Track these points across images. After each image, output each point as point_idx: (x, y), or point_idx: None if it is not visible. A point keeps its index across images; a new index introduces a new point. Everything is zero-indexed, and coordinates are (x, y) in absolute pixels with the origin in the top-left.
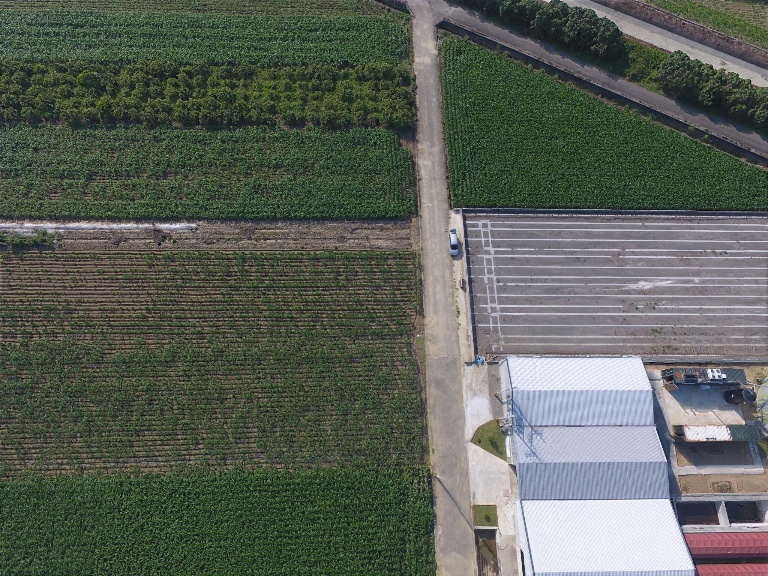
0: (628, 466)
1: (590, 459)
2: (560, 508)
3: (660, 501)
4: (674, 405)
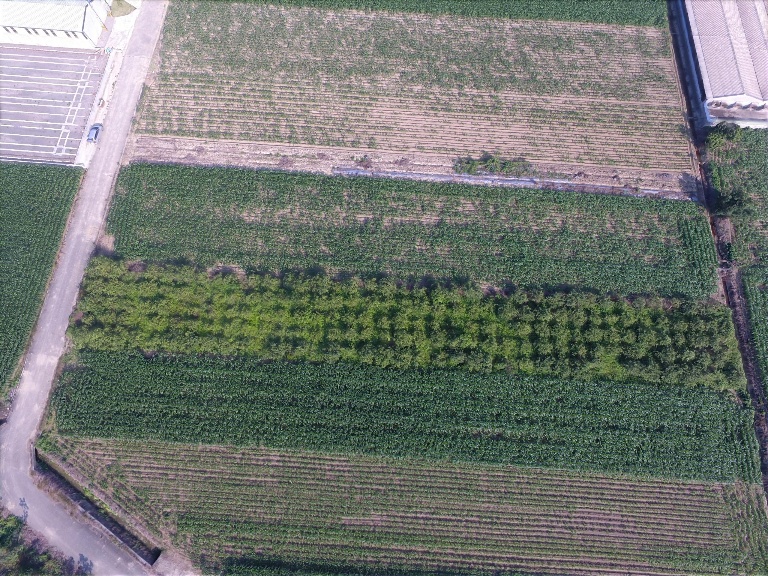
0: None
1: None
2: None
3: None
4: None
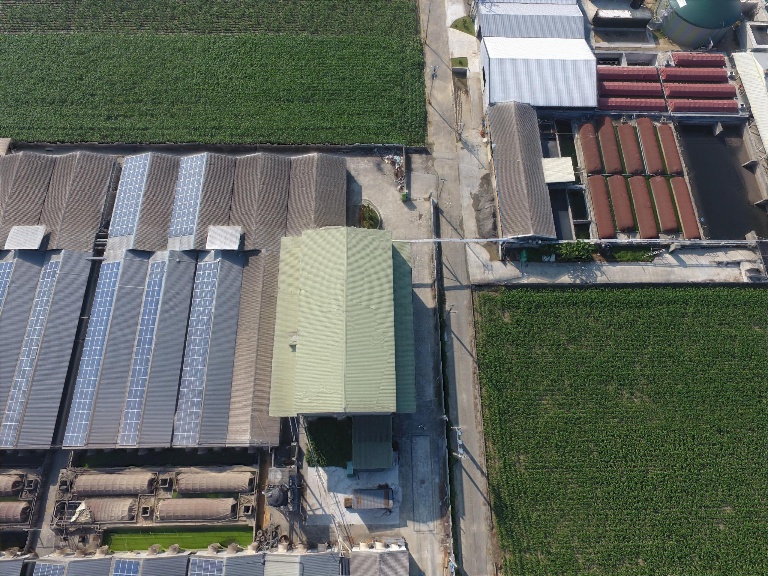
0: (556, 18)
1: (530, 14)
2: (509, 39)
3: (578, 39)
4: (594, 9)
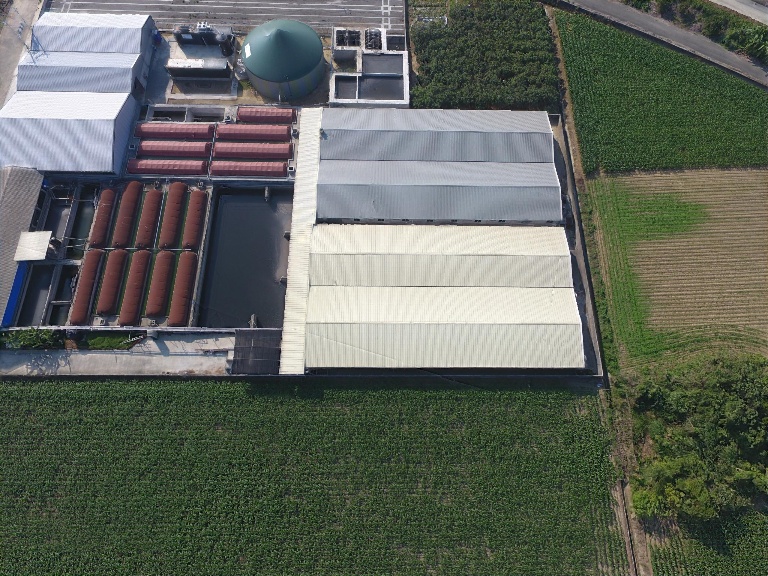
0: (101, 70)
1: (74, 65)
2: (42, 94)
3: (121, 93)
4: (181, 56)
